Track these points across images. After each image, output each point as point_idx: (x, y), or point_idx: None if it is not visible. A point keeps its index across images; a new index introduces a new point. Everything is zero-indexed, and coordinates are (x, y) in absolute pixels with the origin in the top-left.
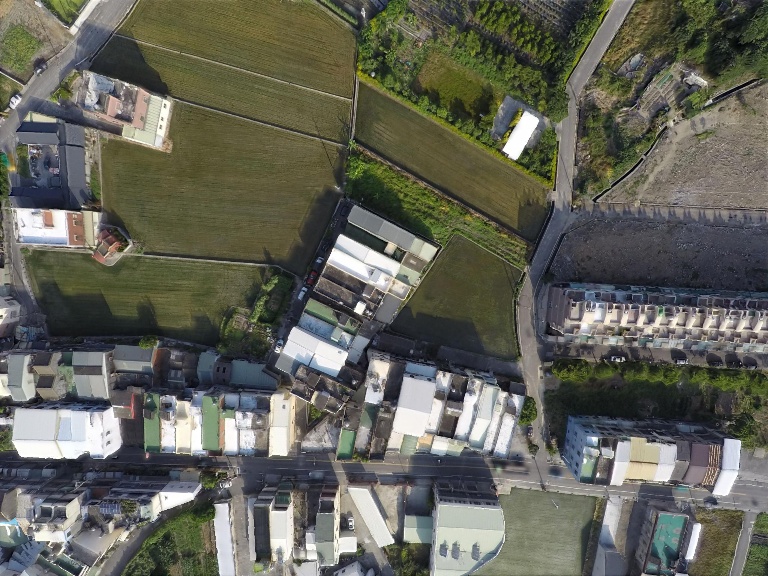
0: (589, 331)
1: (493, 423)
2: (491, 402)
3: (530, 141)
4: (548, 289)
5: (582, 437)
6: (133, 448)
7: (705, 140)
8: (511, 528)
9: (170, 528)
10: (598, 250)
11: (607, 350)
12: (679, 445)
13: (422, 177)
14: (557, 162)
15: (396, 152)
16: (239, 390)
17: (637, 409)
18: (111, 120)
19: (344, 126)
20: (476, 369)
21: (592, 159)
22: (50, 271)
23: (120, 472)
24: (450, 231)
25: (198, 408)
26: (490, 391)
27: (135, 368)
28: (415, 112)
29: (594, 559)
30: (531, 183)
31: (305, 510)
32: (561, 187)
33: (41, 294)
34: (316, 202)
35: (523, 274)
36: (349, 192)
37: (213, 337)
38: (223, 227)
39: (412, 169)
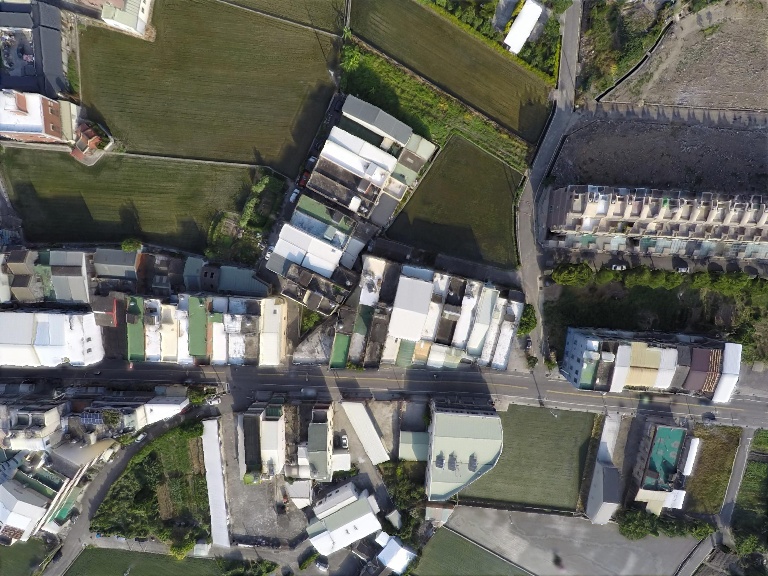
0: (591, 228)
1: (491, 332)
2: (490, 307)
3: (532, 35)
4: (549, 193)
5: (582, 342)
6: (116, 363)
7: (711, 36)
8: (508, 447)
9: (156, 448)
10: (600, 152)
11: (608, 259)
12: (680, 350)
13: (420, 73)
14: (560, 58)
15: (393, 45)
16: (228, 295)
17: (637, 321)
18: (89, 1)
19: (338, 15)
20: (474, 278)
21: (596, 55)
22: (25, 171)
23: (103, 387)
24: (449, 131)
25: (184, 311)
26: (489, 295)
27: (118, 273)
28: (413, 1)
29: (591, 478)
30: (533, 80)
31: (297, 425)
32: (563, 85)
33: (16, 196)
34: (309, 98)
35: (523, 178)
36: (344, 85)
37: (200, 244)
38: (210, 124)
39: (410, 64)
